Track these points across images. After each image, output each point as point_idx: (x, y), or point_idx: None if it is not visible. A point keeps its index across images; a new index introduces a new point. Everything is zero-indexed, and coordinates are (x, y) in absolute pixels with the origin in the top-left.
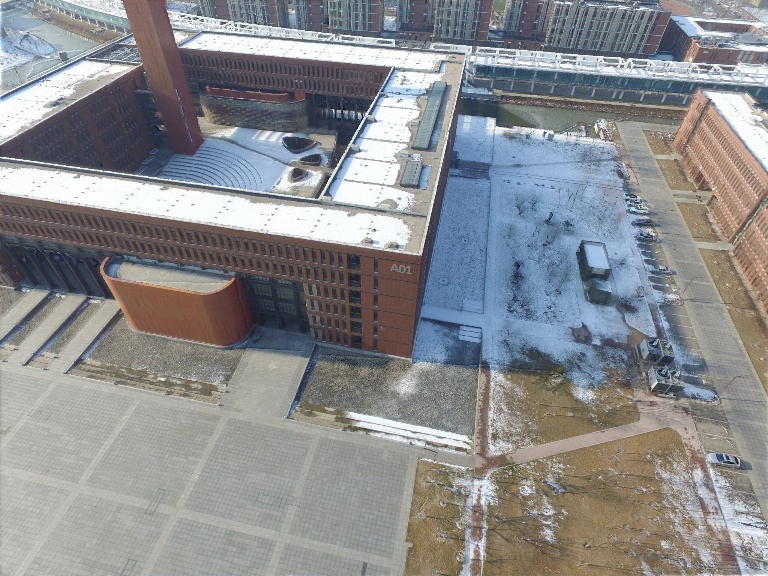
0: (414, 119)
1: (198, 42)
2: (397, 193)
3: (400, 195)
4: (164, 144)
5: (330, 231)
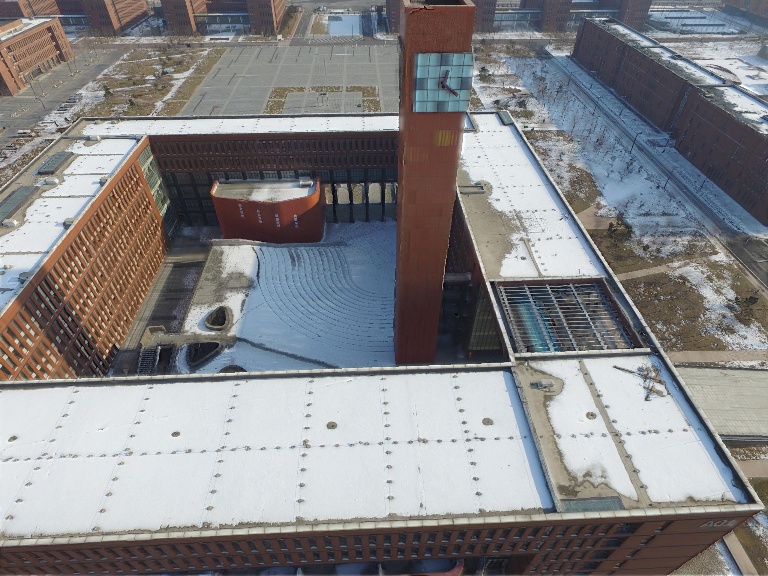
0: (6, 234)
1: (498, 427)
2: (79, 150)
3: (77, 149)
4: (453, 345)
5: (140, 125)
